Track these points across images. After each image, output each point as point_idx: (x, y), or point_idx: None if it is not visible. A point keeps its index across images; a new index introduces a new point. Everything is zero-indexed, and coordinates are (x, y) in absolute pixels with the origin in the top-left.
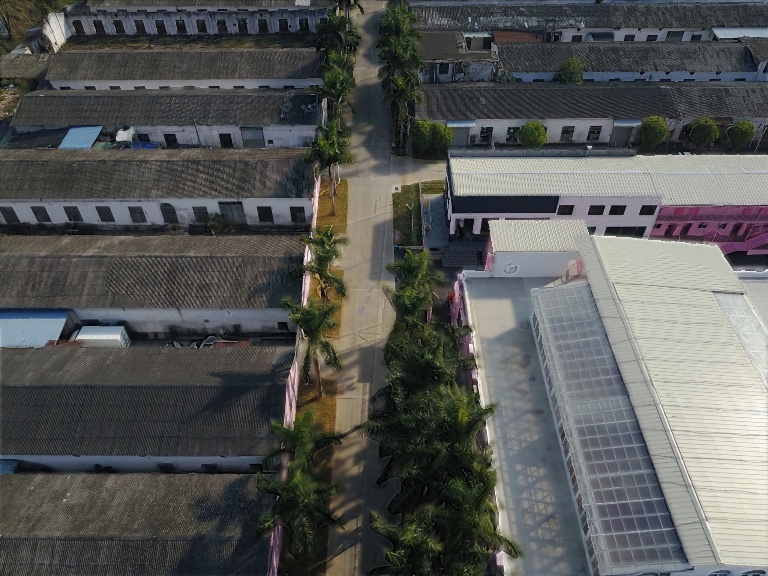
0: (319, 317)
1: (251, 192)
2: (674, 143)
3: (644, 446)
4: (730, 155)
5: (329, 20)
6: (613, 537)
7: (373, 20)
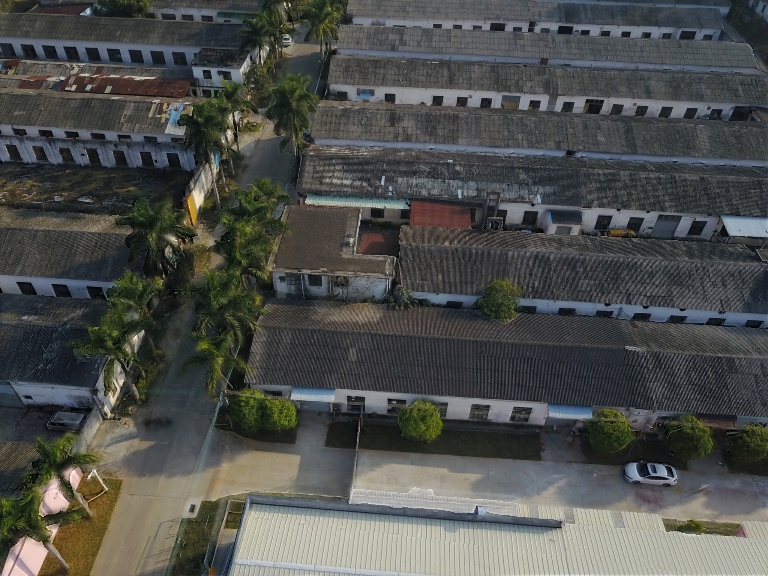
0: None
1: None
2: (644, 433)
3: None
4: (721, 538)
5: (132, 217)
6: None
7: (273, 152)
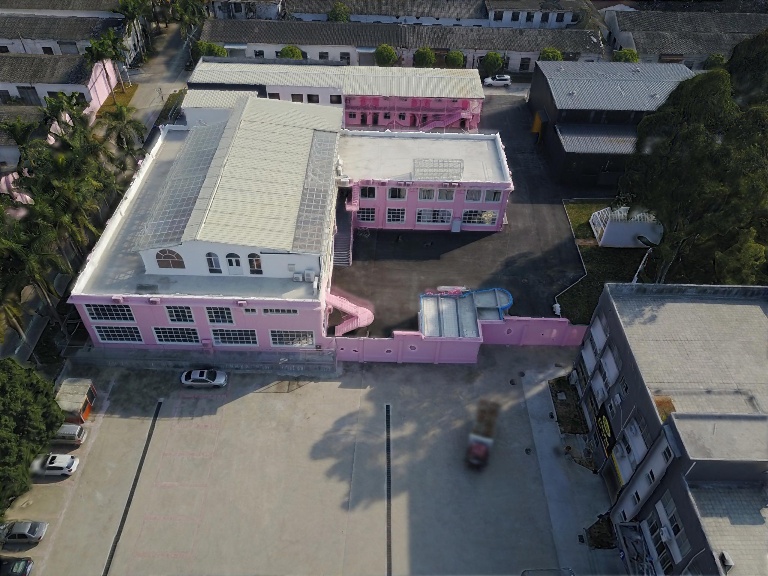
0: (21, 129)
1: (41, 79)
2: None
3: (198, 195)
4: (418, 68)
5: None
6: (150, 235)
7: None
